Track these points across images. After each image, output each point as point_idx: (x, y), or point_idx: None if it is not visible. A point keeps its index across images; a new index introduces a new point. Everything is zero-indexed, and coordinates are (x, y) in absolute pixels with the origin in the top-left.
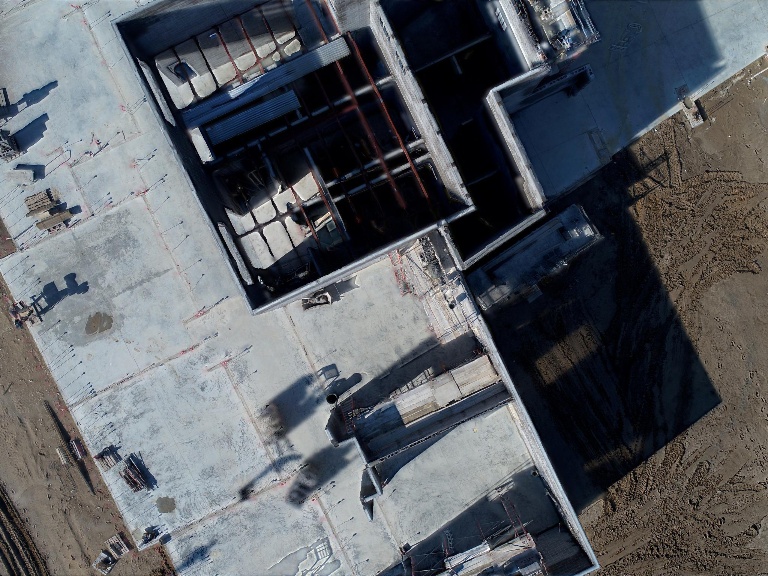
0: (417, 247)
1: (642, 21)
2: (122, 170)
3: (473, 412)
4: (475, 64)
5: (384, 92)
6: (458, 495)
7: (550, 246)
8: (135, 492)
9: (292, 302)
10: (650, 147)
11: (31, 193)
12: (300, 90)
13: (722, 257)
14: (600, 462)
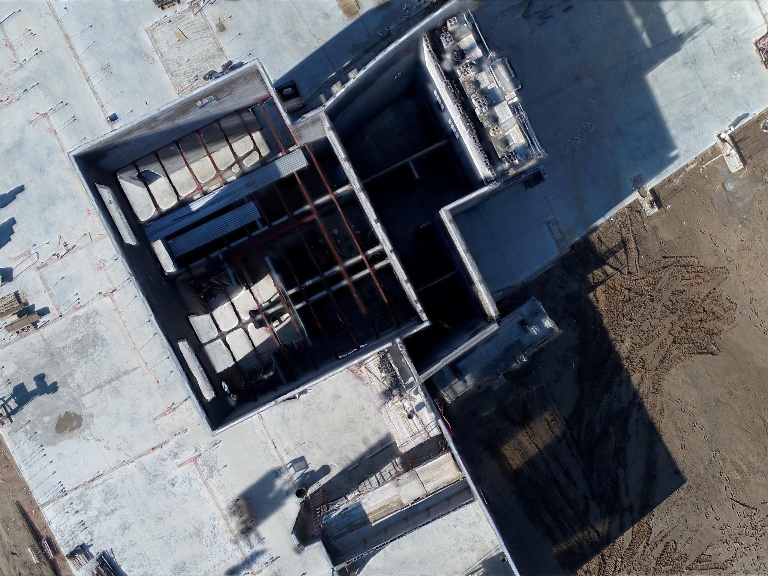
0: (375, 358)
1: None
2: (89, 271)
3: (437, 513)
4: (434, 160)
5: (343, 196)
6: None
7: (511, 338)
8: None
9: None
10: (607, 235)
11: None
12: (259, 201)
13: (681, 340)
14: (568, 545)
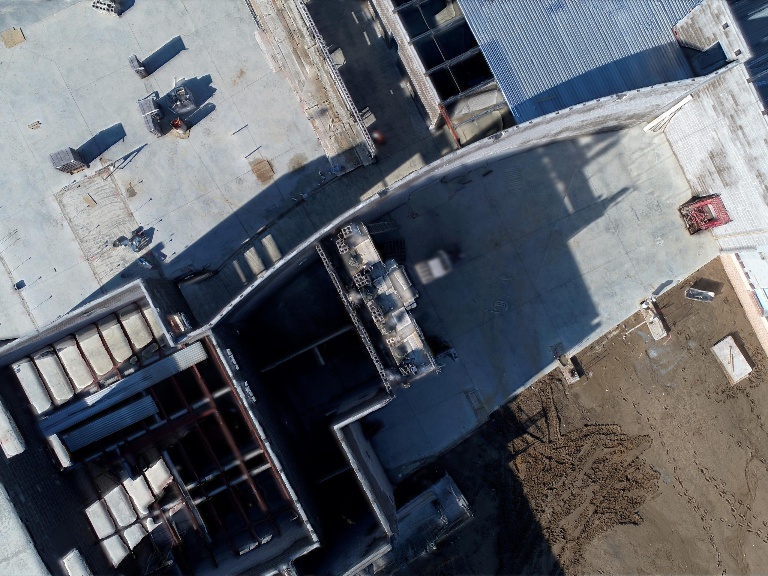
0: None
1: (516, 281)
2: None
3: None
4: None
5: None
6: None
7: (425, 518)
8: None
9: None
10: (528, 404)
11: None
12: (158, 395)
13: (603, 510)
14: None
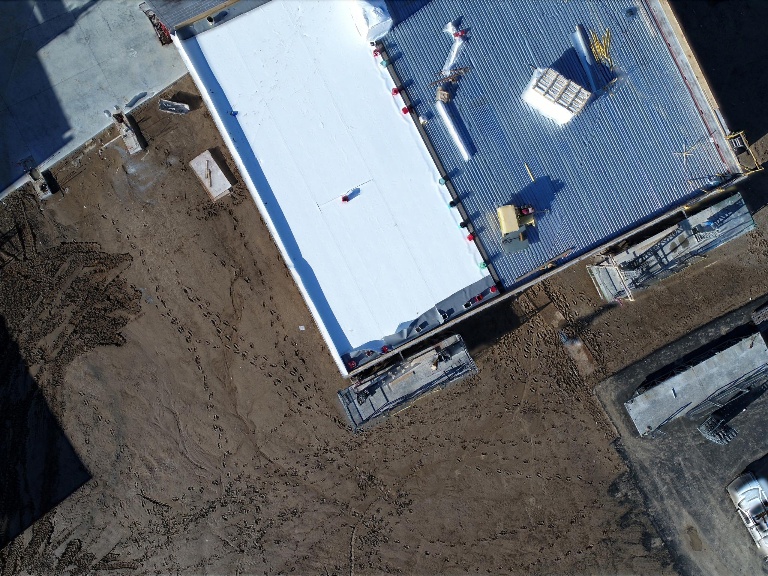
0: None
1: None
2: None
3: None
4: None
5: None
6: None
7: None
8: None
9: None
10: None
11: None
12: None
13: (83, 330)
14: None
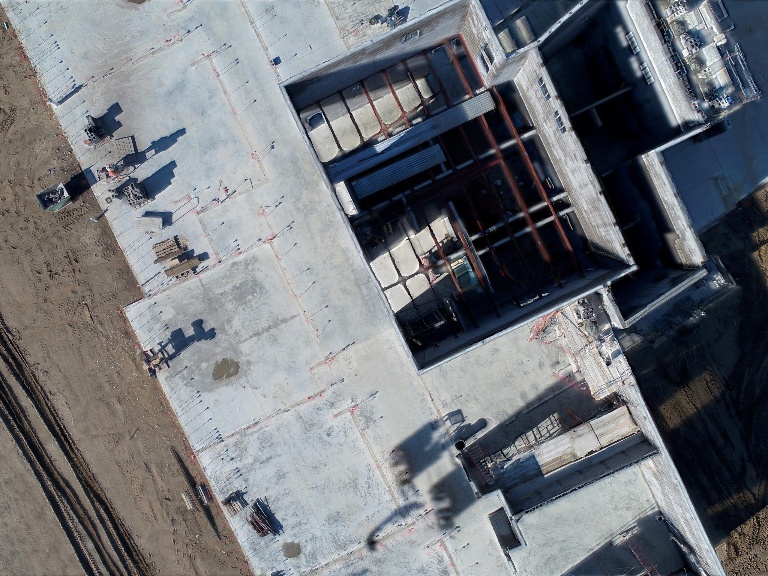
0: (572, 304)
1: None
2: (249, 217)
3: (618, 464)
4: (602, 111)
5: None
6: (583, 540)
7: (681, 294)
8: (261, 537)
9: None
10: None
11: (159, 240)
12: (445, 144)
13: None
14: (723, 506)
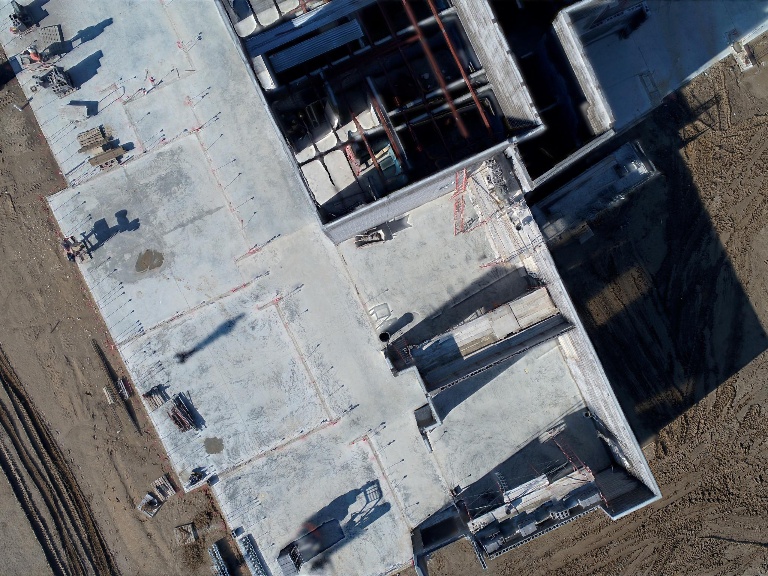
0: (483, 170)
1: None
2: (175, 107)
3: (534, 341)
4: (528, 6)
5: None
6: (509, 437)
7: (604, 184)
8: (183, 432)
9: (344, 241)
10: (700, 90)
11: (84, 129)
12: (363, 19)
13: None
14: (651, 405)
